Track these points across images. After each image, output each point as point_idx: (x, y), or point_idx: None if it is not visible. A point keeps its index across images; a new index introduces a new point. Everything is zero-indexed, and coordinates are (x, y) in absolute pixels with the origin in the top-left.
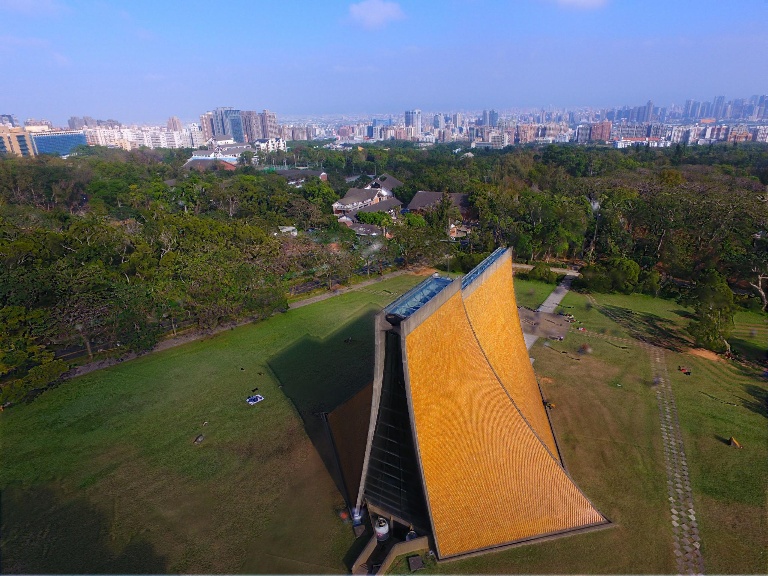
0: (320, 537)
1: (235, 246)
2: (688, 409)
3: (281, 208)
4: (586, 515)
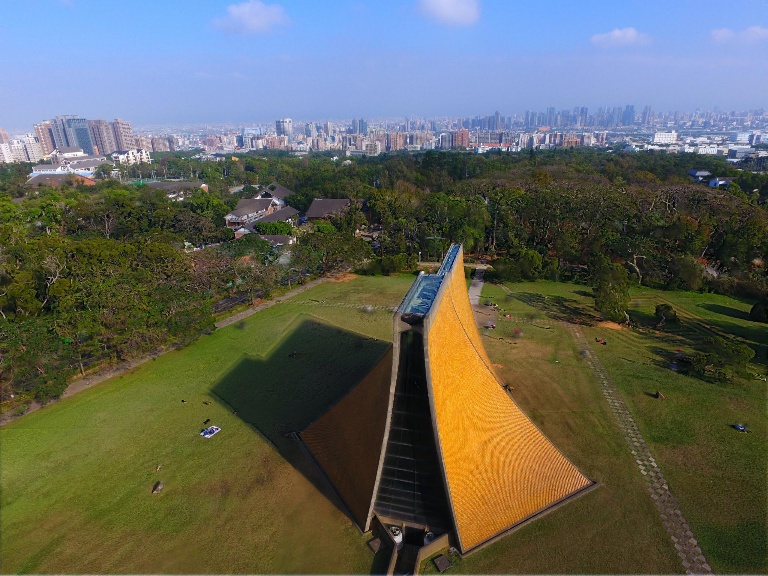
0: (337, 562)
1: (142, 266)
2: (617, 373)
3: (167, 223)
4: (576, 481)
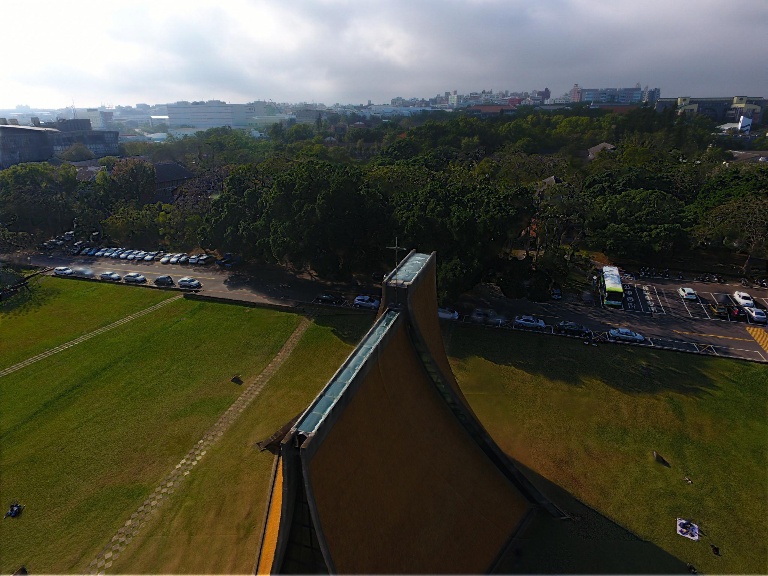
0: None
1: None
2: None
3: None
4: None
